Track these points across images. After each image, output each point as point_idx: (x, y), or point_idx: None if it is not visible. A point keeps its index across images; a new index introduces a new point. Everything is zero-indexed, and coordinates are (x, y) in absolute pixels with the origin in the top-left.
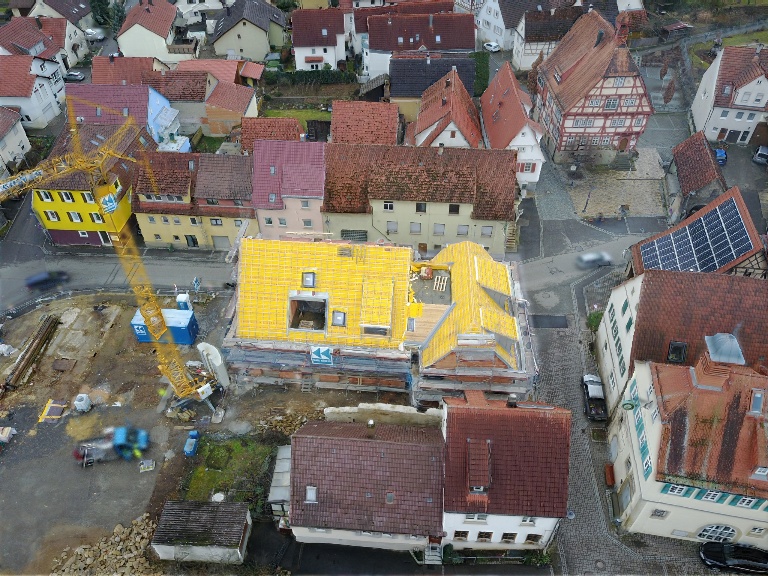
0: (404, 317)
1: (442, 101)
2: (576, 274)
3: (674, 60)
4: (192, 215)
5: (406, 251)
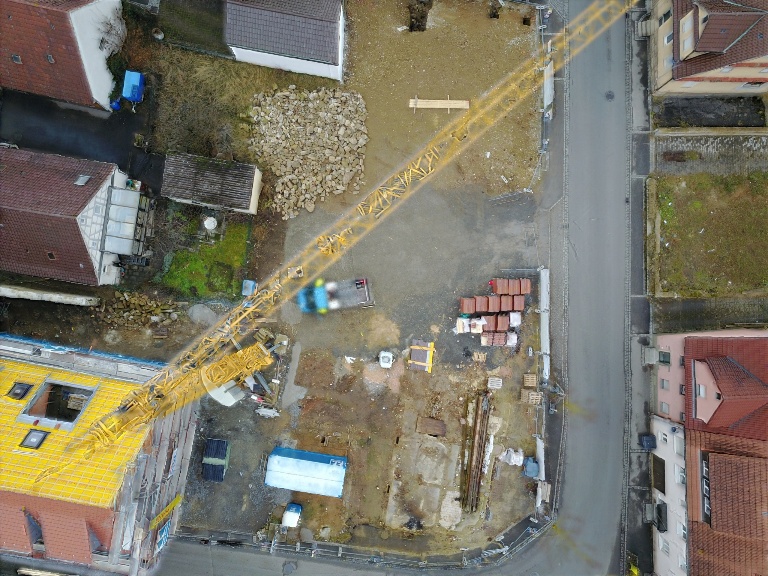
0: None
1: None
2: None
3: None
4: None
5: None
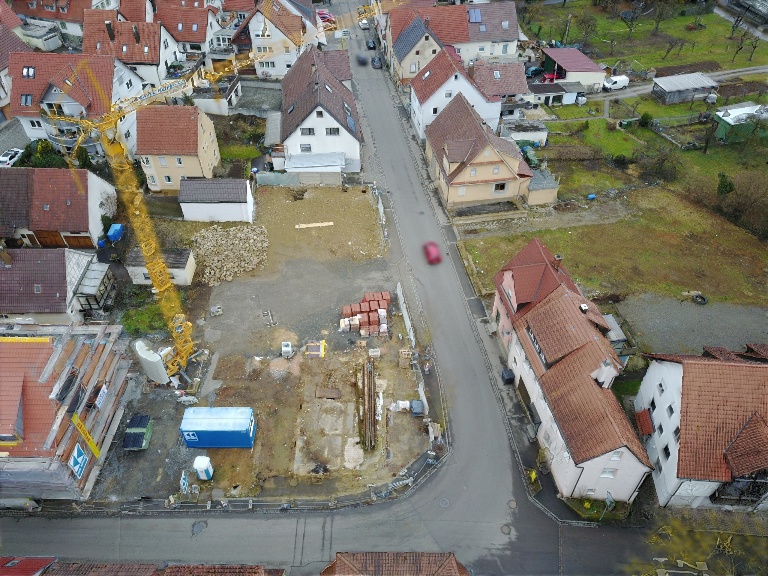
0: None
1: None
2: None
3: None
4: None
5: None
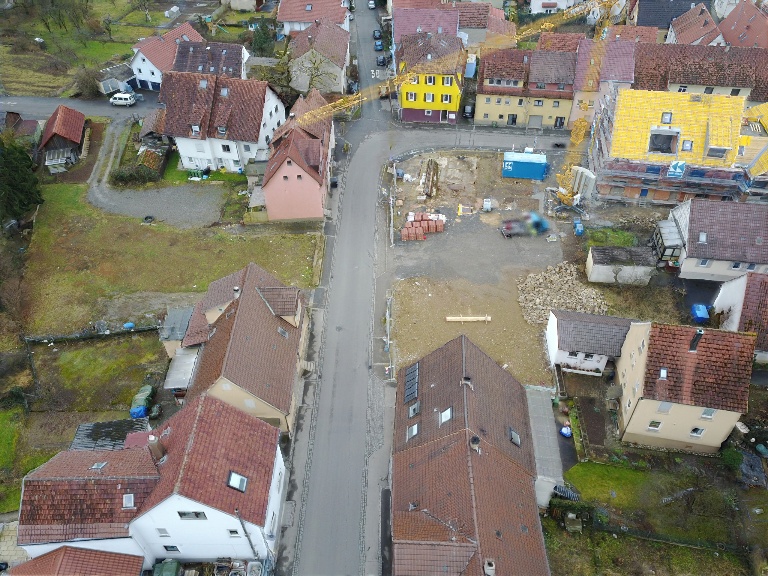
0: (736, 145)
1: (705, 22)
2: None
3: None
4: (523, 96)
5: (742, 98)
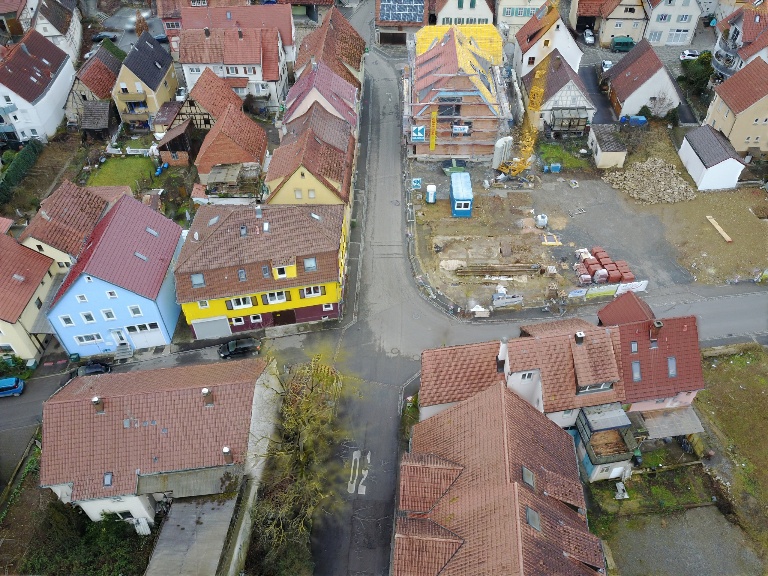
0: None
1: (240, 33)
2: (378, 57)
3: (117, 2)
4: None
5: None
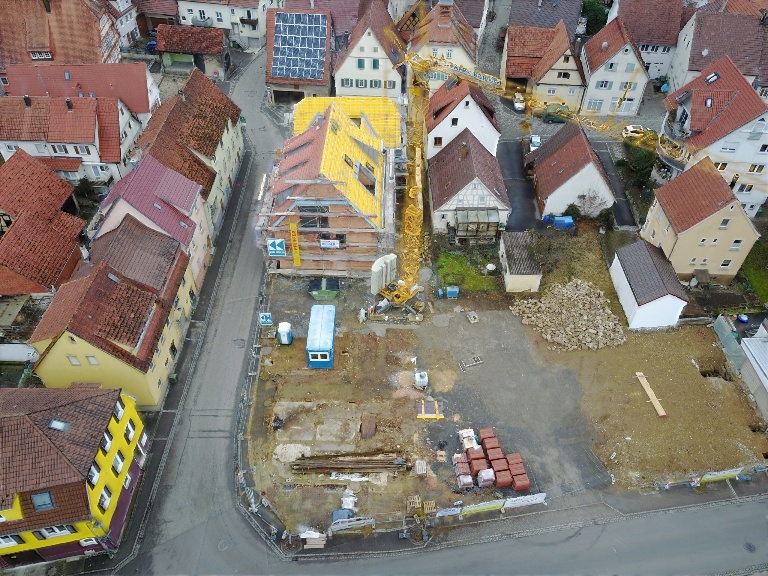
0: None
1: (69, 103)
2: (268, 121)
3: None
4: None
5: None
